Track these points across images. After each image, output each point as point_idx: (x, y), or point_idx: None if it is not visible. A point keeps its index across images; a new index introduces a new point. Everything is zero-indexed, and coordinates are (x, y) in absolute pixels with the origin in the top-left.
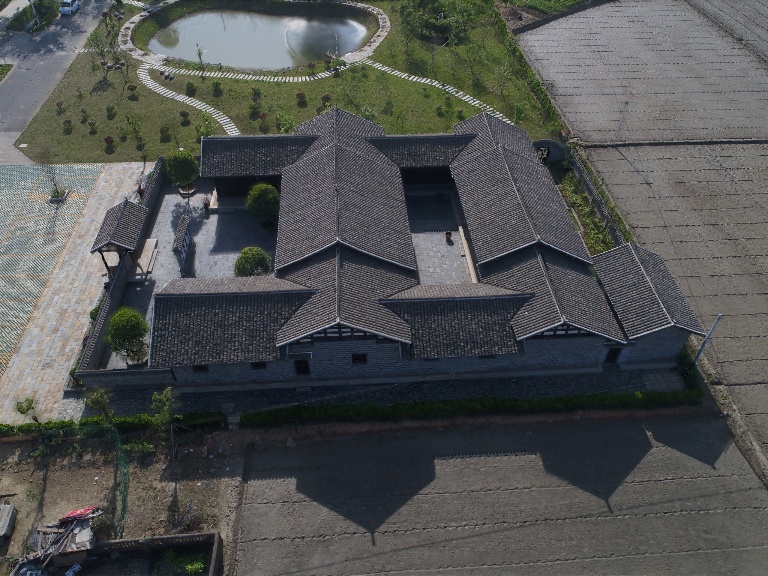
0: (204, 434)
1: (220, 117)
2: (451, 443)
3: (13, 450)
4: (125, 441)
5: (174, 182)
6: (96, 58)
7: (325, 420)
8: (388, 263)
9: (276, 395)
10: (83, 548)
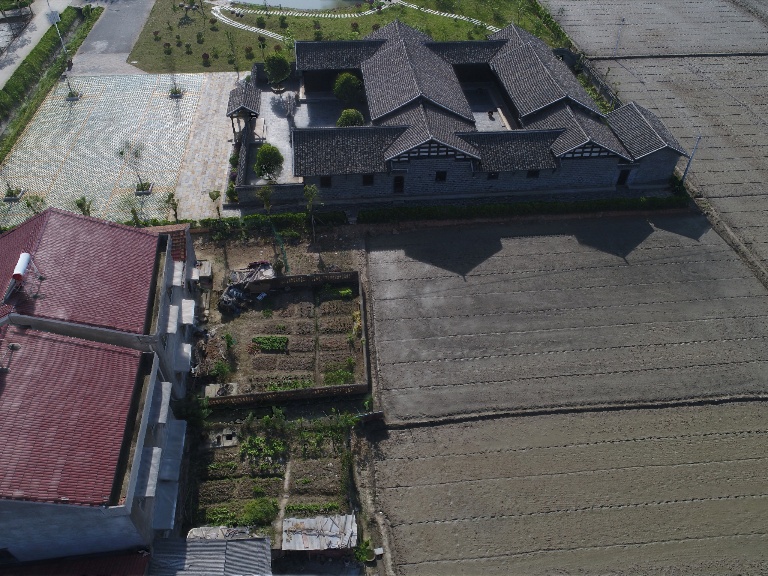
0: (333, 226)
1: None
2: (511, 231)
3: (197, 237)
4: (277, 231)
5: (270, 80)
6: (173, 2)
7: (418, 219)
8: (456, 115)
9: (379, 206)
10: (270, 278)
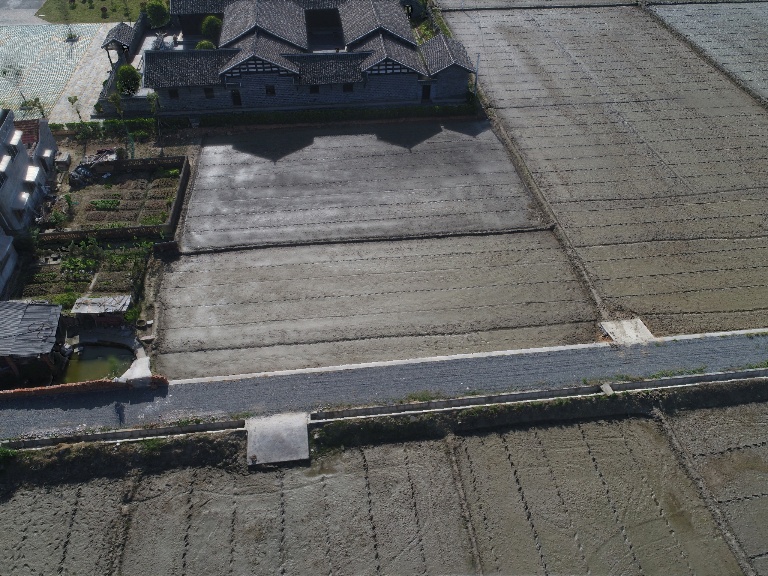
0: (178, 129)
1: None
2: (325, 132)
3: (64, 138)
4: (131, 132)
5: (152, 26)
6: None
7: (250, 124)
8: (289, 43)
9: None
10: (112, 160)
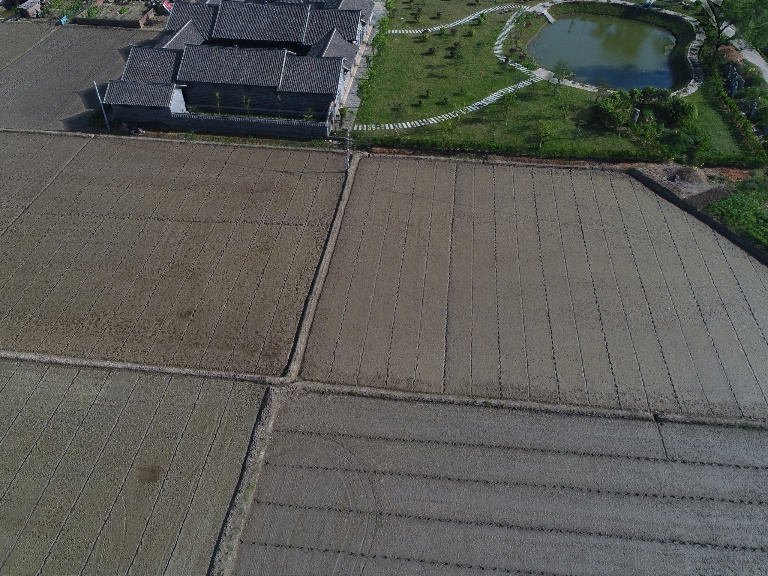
0: None
1: None
2: None
3: None
4: None
5: None
6: None
7: None
8: None
9: None
10: (153, 4)
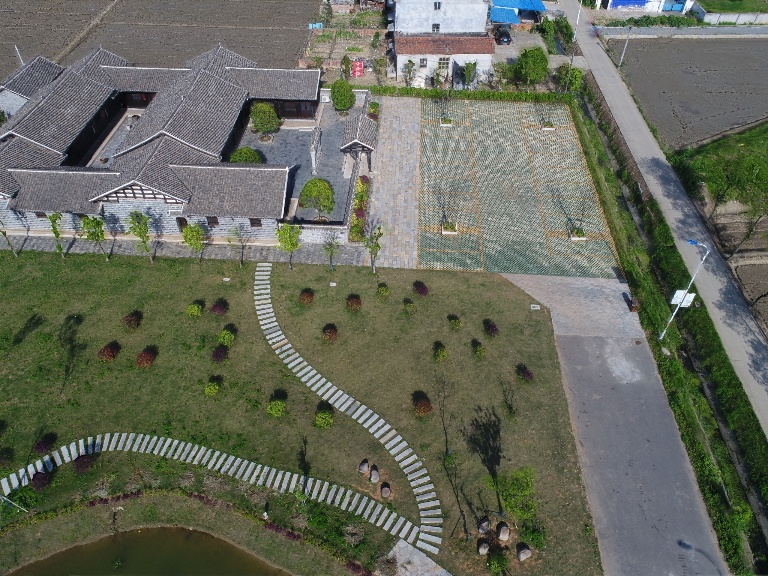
0: None
1: (280, 342)
2: None
3: None
4: None
5: None
6: None
7: None
8: None
9: None
10: None
